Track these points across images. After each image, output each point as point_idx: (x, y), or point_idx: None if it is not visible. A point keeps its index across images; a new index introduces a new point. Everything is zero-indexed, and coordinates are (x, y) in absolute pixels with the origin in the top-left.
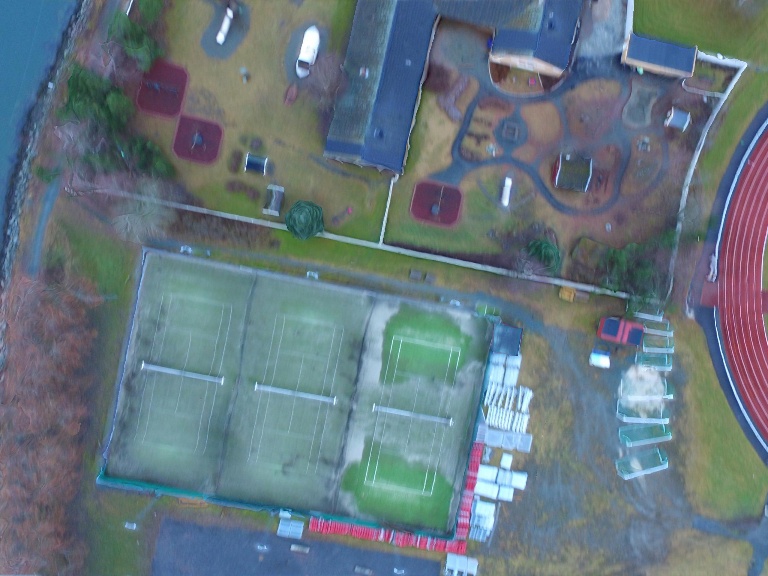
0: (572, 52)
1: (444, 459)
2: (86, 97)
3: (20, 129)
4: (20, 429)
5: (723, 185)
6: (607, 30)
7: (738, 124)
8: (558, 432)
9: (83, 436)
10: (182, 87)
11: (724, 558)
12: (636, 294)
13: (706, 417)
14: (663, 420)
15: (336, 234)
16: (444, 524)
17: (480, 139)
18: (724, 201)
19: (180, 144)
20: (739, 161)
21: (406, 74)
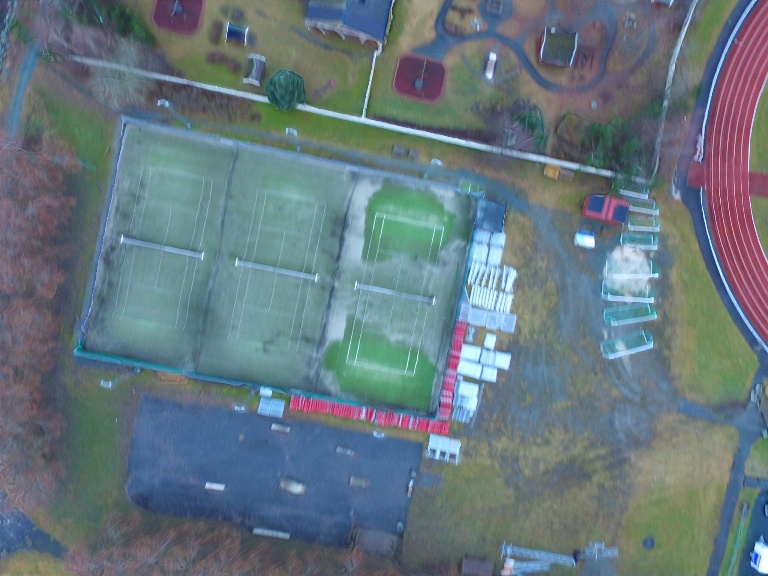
0: None
1: (427, 339)
2: None
3: None
4: None
5: (710, 64)
6: None
7: (725, 2)
8: (542, 313)
9: (61, 308)
10: None
11: (710, 443)
12: (621, 171)
13: (692, 300)
14: (648, 299)
15: (318, 108)
16: (427, 405)
17: (464, 13)
18: (711, 80)
19: (160, 14)
20: (726, 40)
21: None
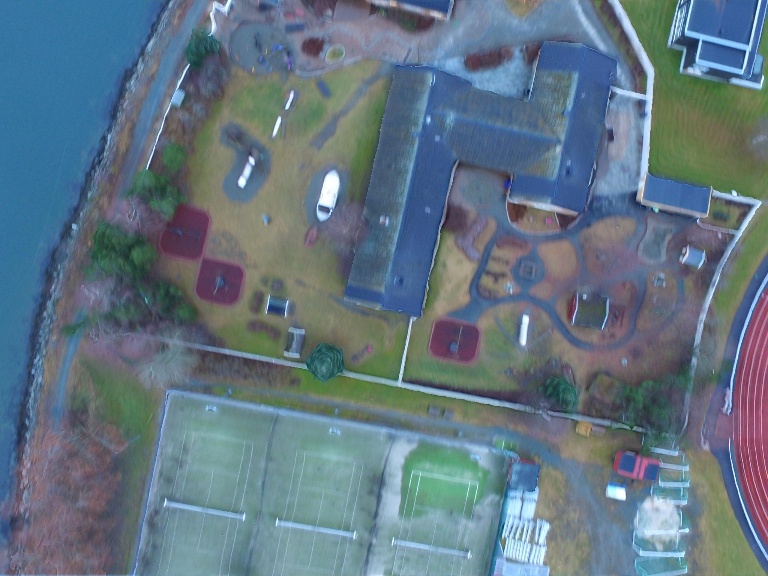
0: (588, 191)
1: None
2: (112, 253)
3: (44, 269)
4: (46, 575)
5: (737, 318)
6: (623, 169)
7: (752, 258)
8: (575, 563)
9: (107, 575)
10: (204, 231)
11: None
12: (652, 430)
13: (721, 547)
14: (679, 554)
15: (356, 372)
16: None
17: (498, 277)
18: (739, 335)
19: (202, 286)
20: (753, 295)
21: (425, 220)
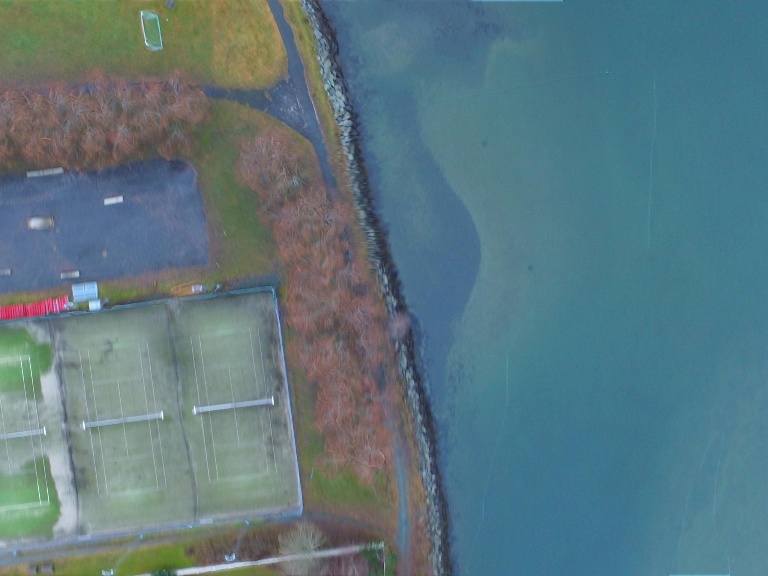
0: None
1: None
2: None
3: (455, 569)
4: None
5: None
6: None
7: None
8: None
9: None
10: None
11: None
12: None
13: None
14: None
15: None
16: None
17: None
18: None
19: None
20: None
21: None
